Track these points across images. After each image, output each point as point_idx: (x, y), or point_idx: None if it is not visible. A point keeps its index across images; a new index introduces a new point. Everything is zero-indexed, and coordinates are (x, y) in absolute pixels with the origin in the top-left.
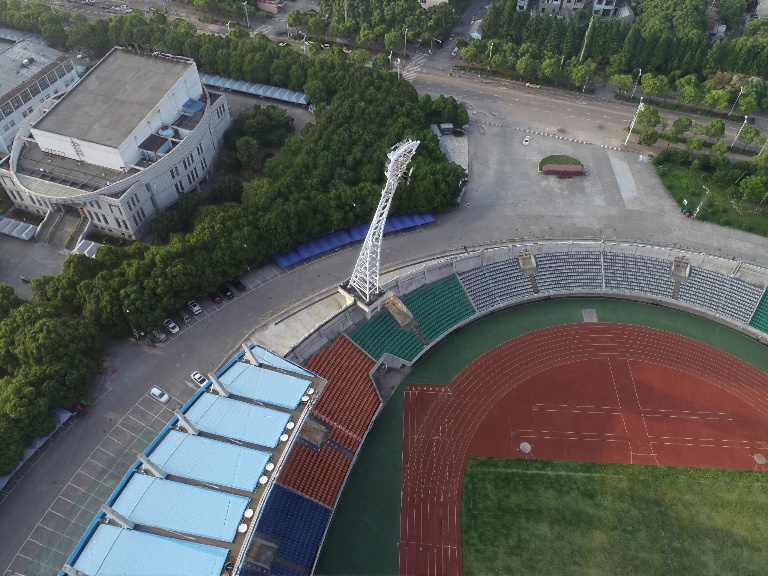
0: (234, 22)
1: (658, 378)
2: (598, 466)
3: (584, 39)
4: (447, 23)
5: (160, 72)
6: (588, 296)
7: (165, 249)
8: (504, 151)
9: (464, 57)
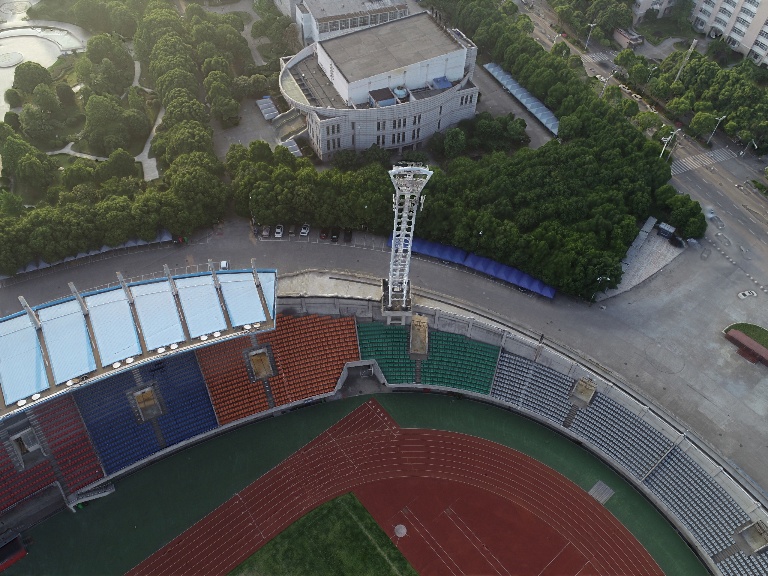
0: (577, 39)
1: None
2: None
3: None
4: None
5: (436, 44)
6: (623, 475)
7: None
8: (707, 288)
9: None
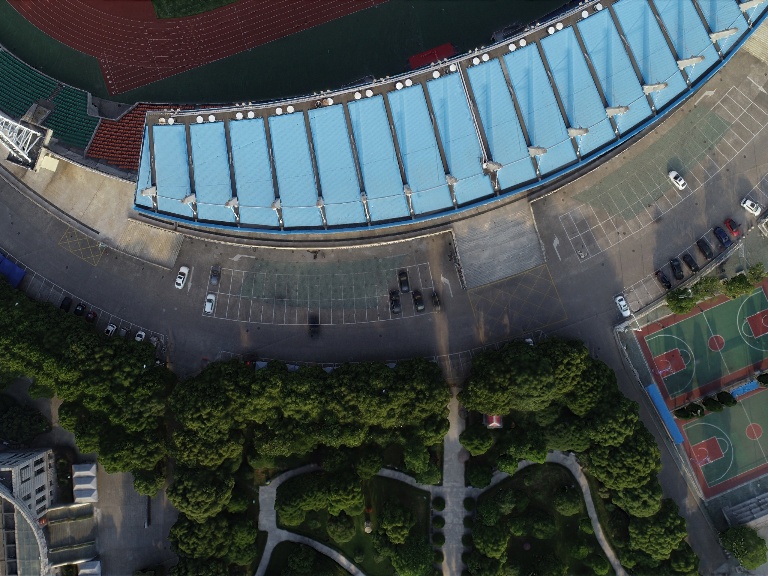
0: None
1: None
2: None
3: None
4: None
5: None
6: None
7: None
8: None
9: None
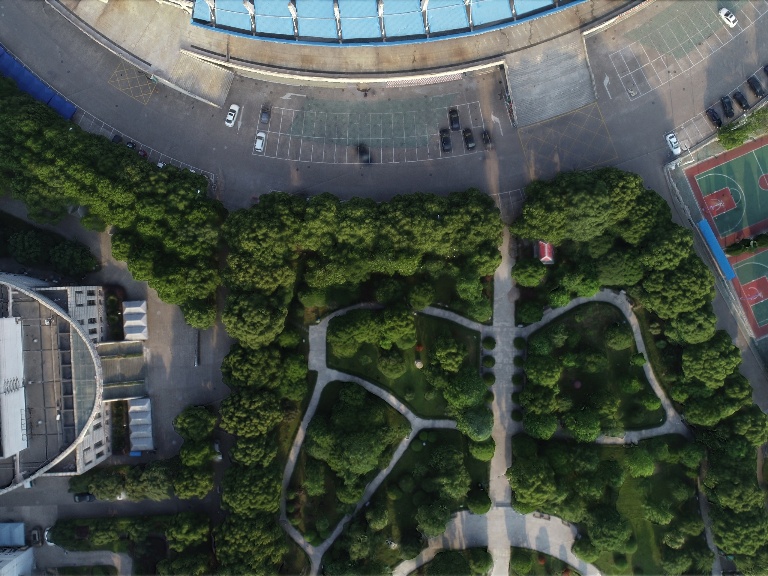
0: None
1: None
2: None
3: None
4: None
5: None
6: None
7: None
8: None
9: None
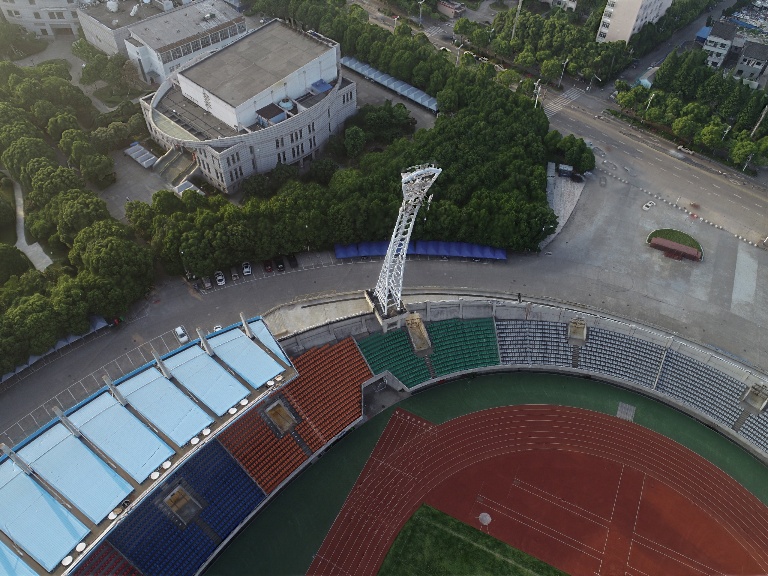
0: (408, 18)
1: (672, 508)
2: (553, 571)
3: (762, 113)
4: (617, 63)
5: (302, 49)
6: (635, 390)
7: (237, 208)
8: (618, 210)
9: (619, 102)
